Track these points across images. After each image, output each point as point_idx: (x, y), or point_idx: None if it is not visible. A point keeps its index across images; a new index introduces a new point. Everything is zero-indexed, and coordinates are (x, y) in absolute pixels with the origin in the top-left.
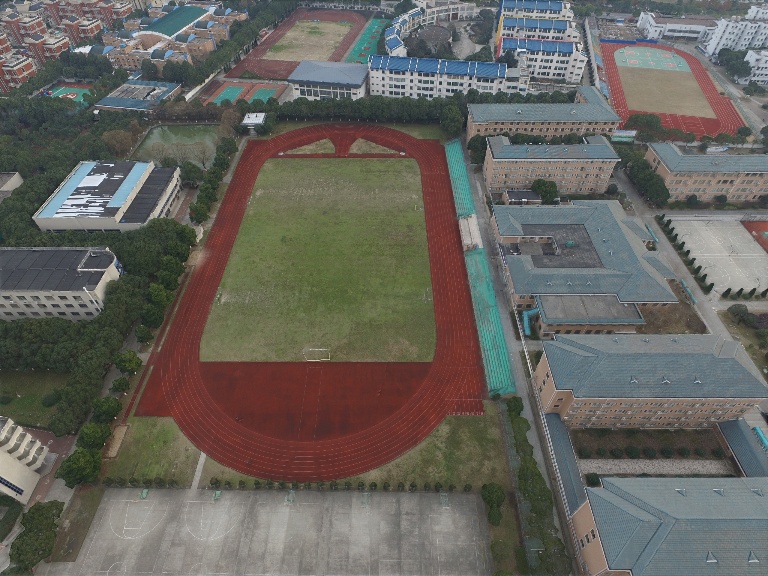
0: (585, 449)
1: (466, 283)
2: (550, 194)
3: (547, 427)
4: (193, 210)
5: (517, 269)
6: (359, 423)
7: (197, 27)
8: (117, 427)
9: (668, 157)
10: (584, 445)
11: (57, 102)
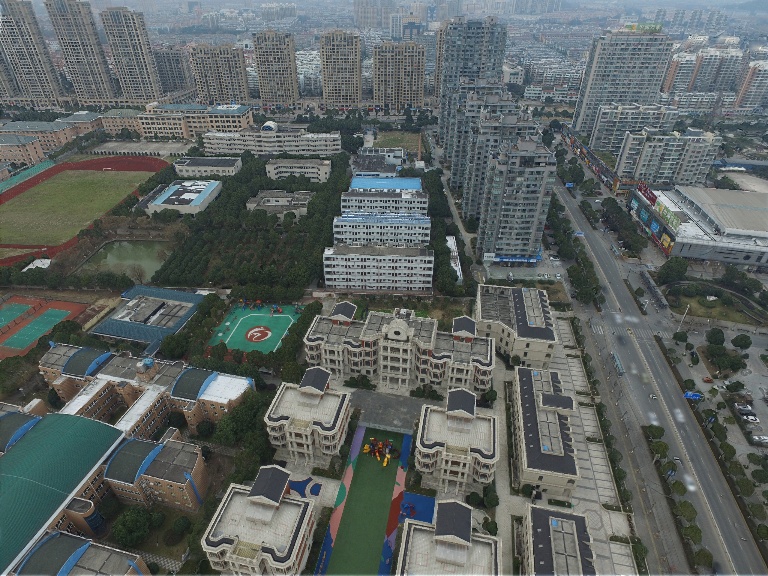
0: None
1: None
2: None
3: None
4: None
5: None
6: None
7: None
8: None
9: None
10: None
11: None
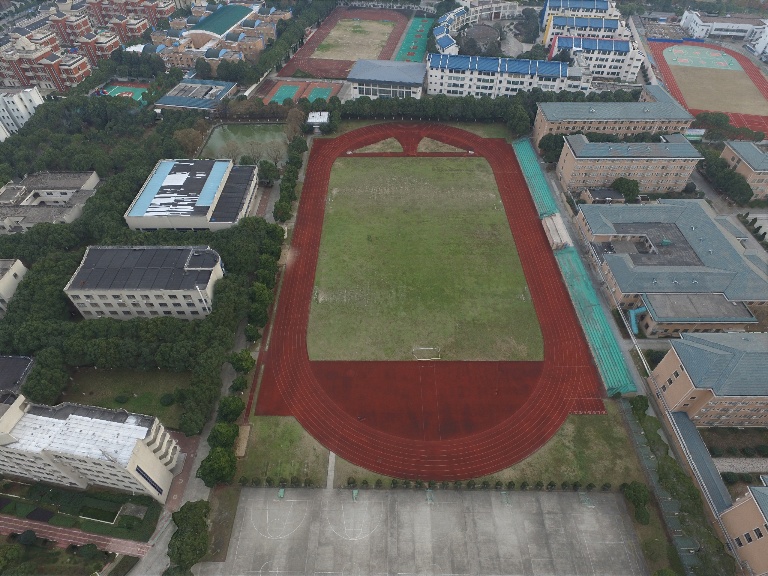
0: (717, 448)
1: (561, 282)
2: (633, 193)
3: (677, 426)
4: (278, 209)
5: (619, 268)
6: (482, 422)
7: (244, 26)
8: (240, 426)
9: (750, 156)
10: (713, 444)
11: None
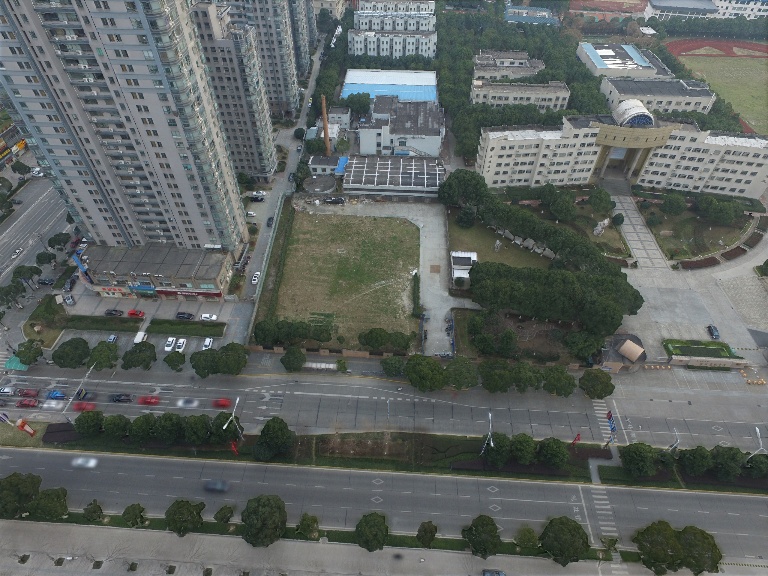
0: None
1: None
2: None
3: None
4: None
5: None
6: None
7: None
8: None
9: None
10: None
11: (480, 16)
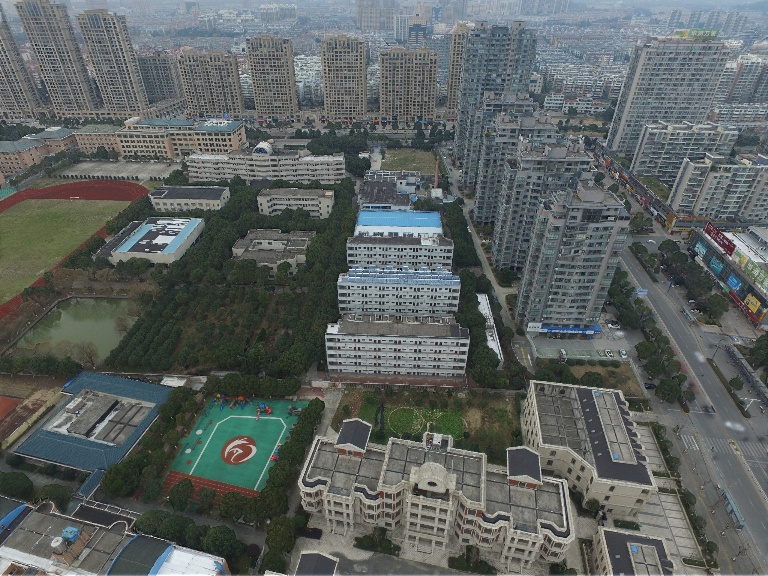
0: None
1: None
2: None
3: None
4: None
5: None
6: None
7: None
8: None
9: None
10: None
11: None
